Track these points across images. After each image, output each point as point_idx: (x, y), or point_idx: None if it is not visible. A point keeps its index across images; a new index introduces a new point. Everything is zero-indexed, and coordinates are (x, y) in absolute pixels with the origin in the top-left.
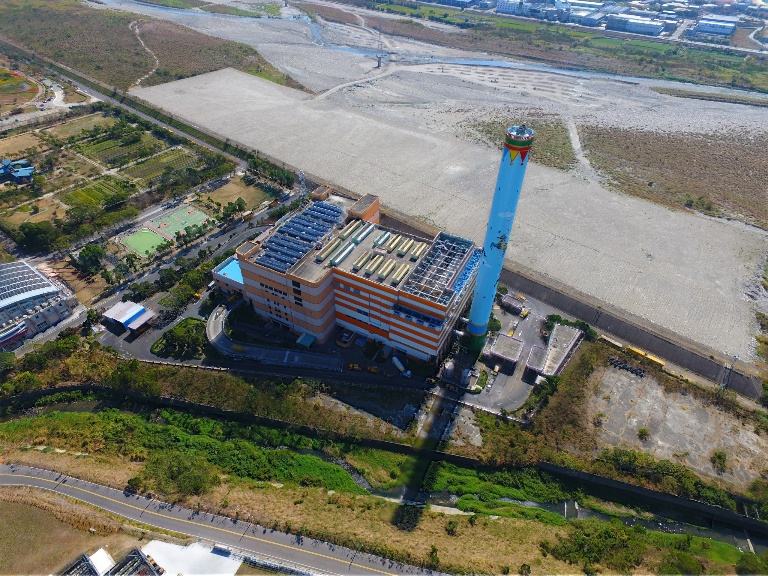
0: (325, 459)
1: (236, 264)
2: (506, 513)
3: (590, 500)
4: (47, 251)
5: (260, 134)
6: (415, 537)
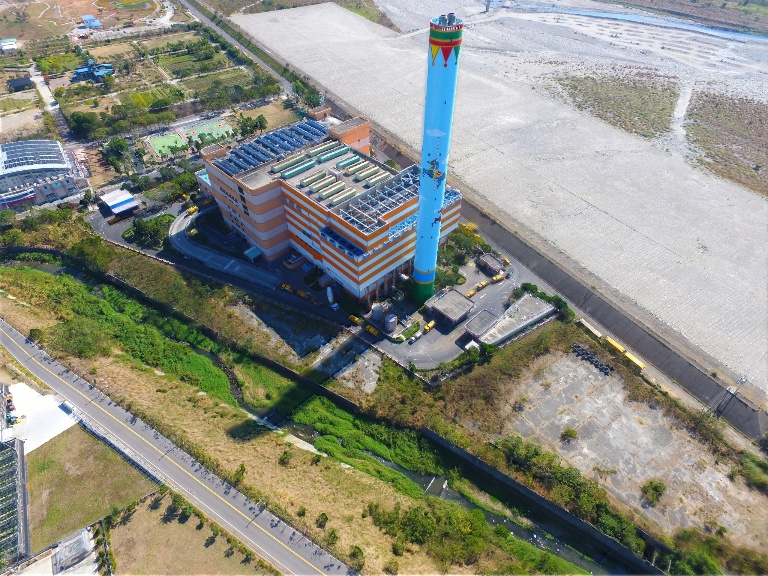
0: (216, 364)
1: None
2: (361, 466)
3: (464, 484)
4: (89, 140)
5: (325, 64)
6: (242, 454)
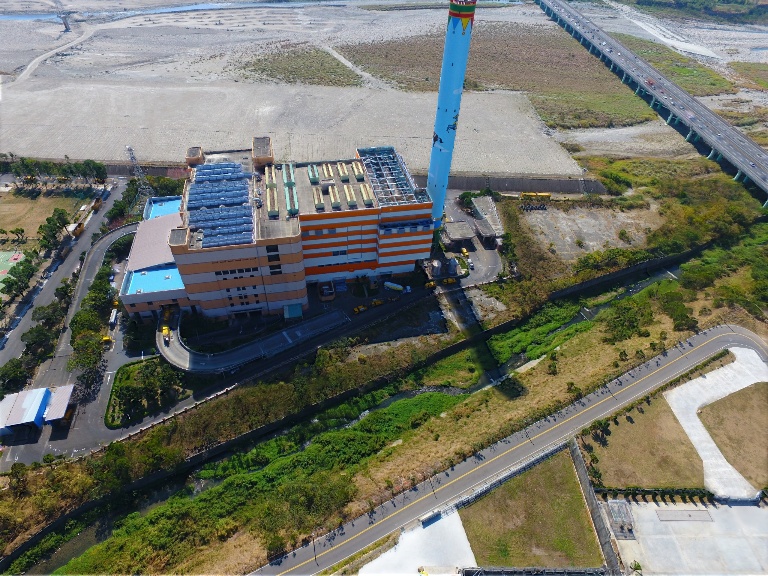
0: (409, 396)
1: (141, 276)
2: (560, 341)
3: (590, 301)
4: None
5: None
6: (542, 392)
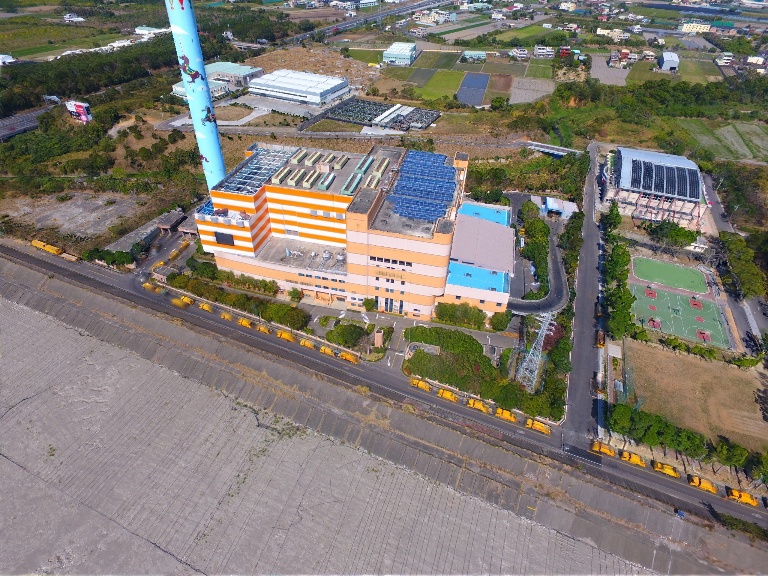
0: None
1: (499, 222)
2: None
3: None
4: None
5: None
6: None
